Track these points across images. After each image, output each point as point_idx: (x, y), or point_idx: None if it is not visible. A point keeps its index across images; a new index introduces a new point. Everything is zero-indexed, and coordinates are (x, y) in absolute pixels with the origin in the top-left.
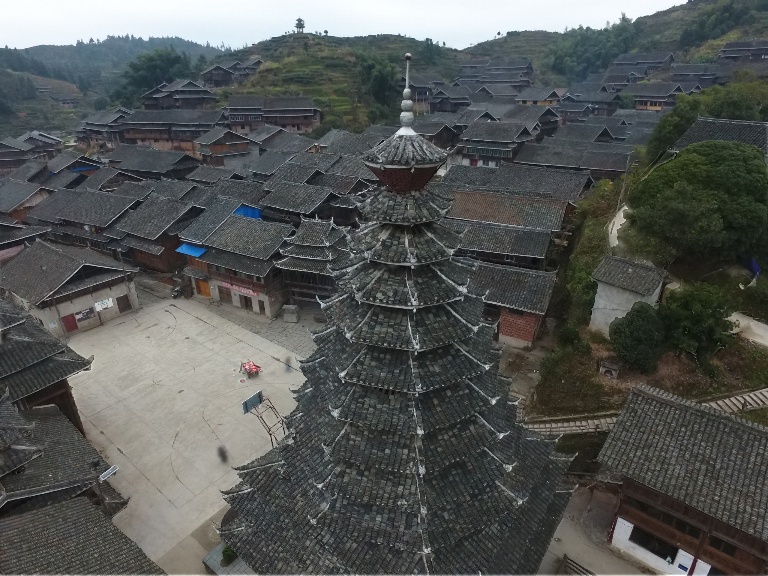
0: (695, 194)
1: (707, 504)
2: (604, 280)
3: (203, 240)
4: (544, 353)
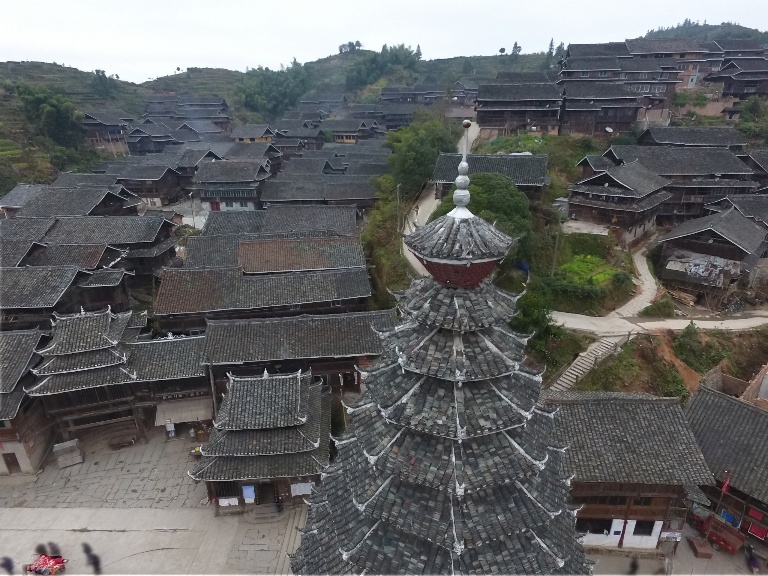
0: None
1: (642, 476)
2: None
3: None
4: None
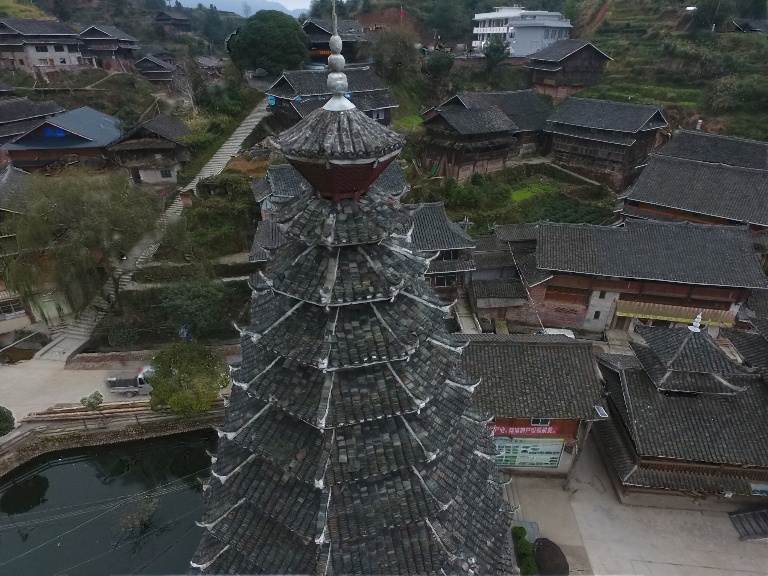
0: None
1: None
2: None
3: None
4: None
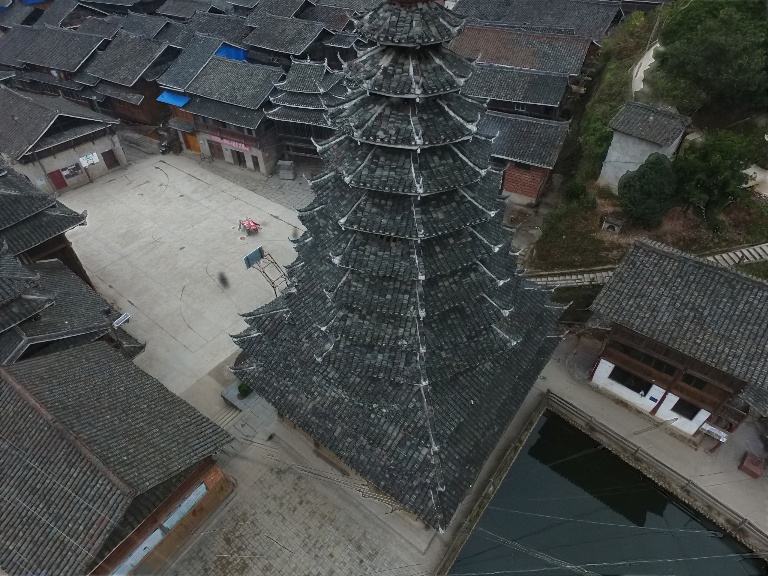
0: (741, 25)
1: (688, 346)
2: (621, 129)
3: (185, 87)
4: (547, 210)
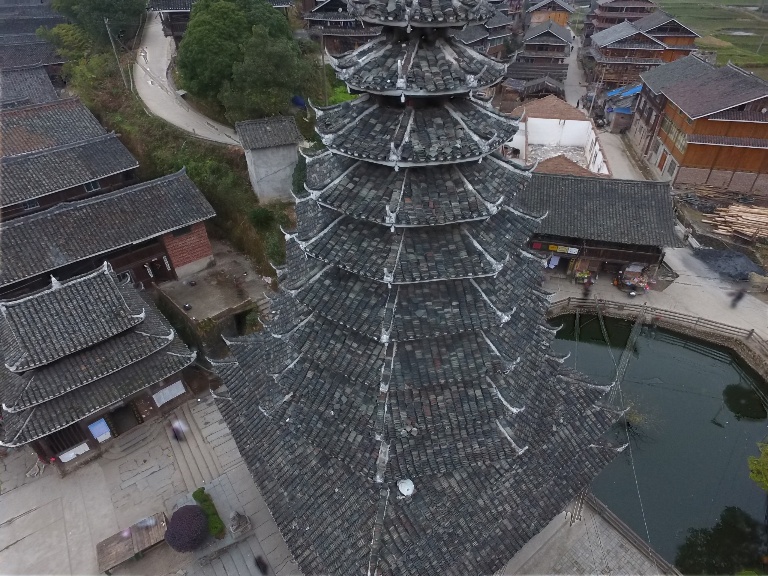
0: None
1: None
2: (259, 146)
3: None
4: (227, 258)
